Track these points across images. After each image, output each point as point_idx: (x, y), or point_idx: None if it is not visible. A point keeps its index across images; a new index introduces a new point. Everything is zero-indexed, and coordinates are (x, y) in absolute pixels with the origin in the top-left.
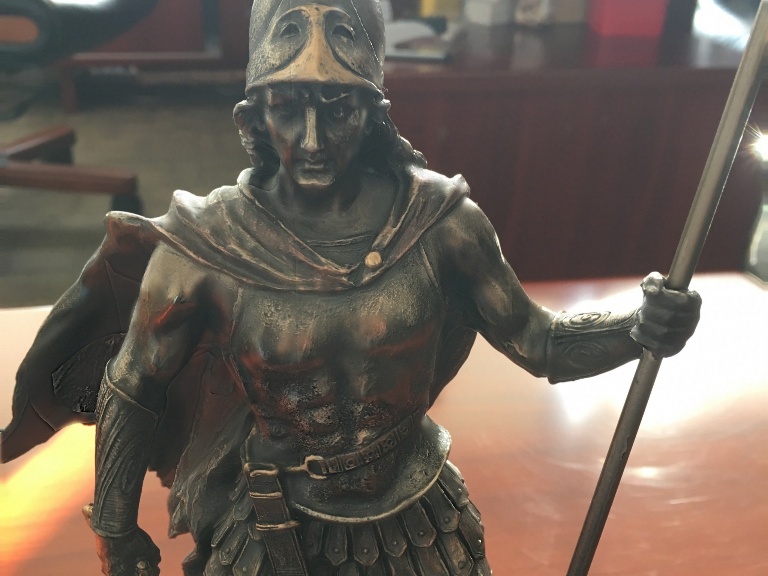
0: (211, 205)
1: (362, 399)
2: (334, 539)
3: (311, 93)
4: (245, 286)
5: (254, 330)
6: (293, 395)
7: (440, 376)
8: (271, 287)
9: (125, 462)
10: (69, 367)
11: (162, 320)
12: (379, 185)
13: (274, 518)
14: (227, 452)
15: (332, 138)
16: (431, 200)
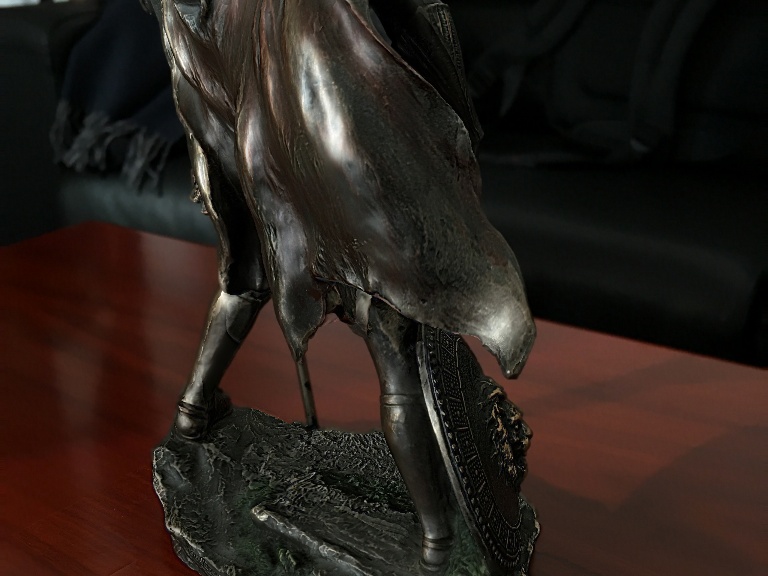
0: None
1: None
2: None
3: None
4: None
5: None
6: None
7: None
8: None
9: None
10: (373, 205)
11: None
12: None
13: None
14: None
15: None
16: None
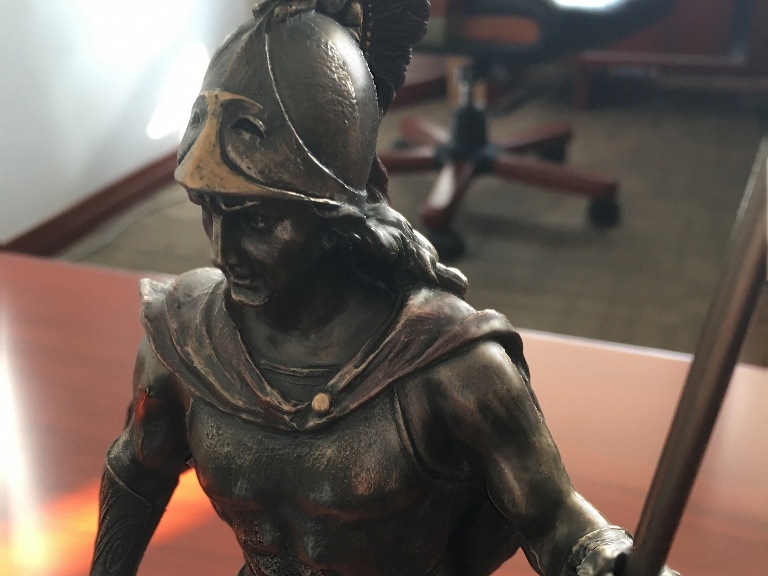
0: (200, 295)
1: (310, 563)
2: None
3: (212, 197)
4: (196, 397)
5: (198, 448)
6: (240, 532)
7: (486, 550)
8: (216, 405)
9: (112, 541)
10: None
11: (141, 408)
12: (374, 307)
13: None
14: None
15: (253, 251)
16: (419, 341)
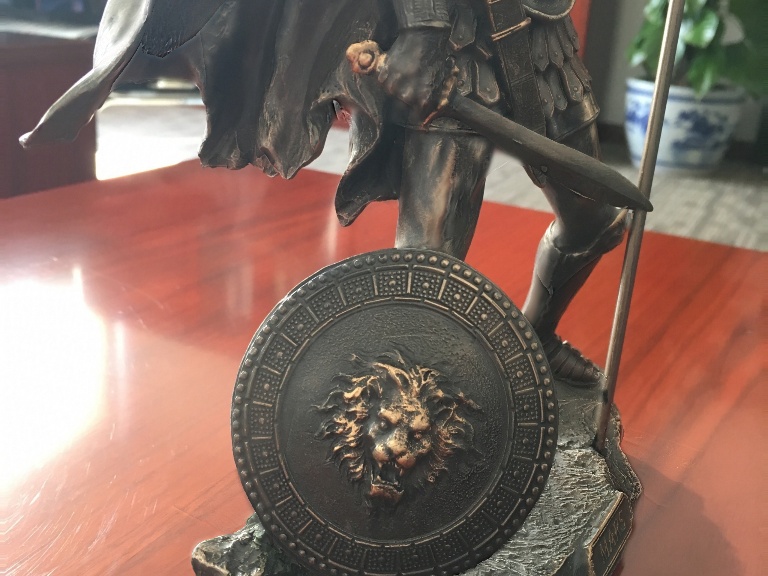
0: None
1: None
2: (538, 45)
3: None
4: None
5: None
6: None
7: None
8: None
9: None
10: None
11: None
12: None
13: (511, 21)
14: (374, 28)
15: None
16: None
